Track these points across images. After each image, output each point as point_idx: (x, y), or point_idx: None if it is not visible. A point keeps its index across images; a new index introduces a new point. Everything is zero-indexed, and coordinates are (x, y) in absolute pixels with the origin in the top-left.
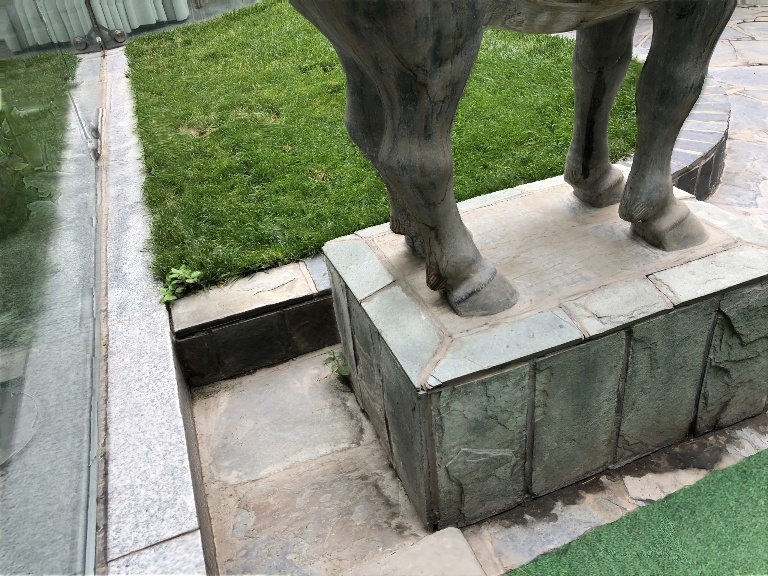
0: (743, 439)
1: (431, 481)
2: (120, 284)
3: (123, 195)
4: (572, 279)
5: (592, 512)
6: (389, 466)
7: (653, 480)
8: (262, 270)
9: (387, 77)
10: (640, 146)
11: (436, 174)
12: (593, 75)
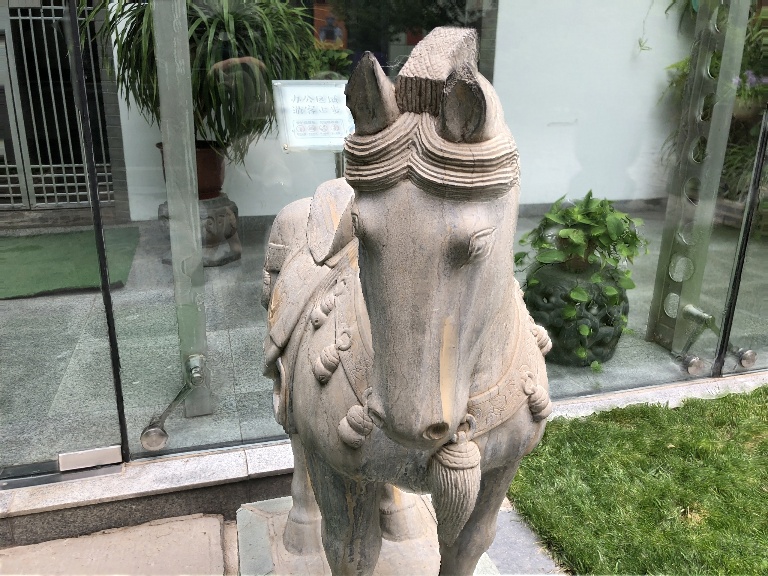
0: None
1: None
2: None
3: (639, 402)
4: None
5: None
6: None
7: None
8: None
9: None
10: None
11: None
12: None
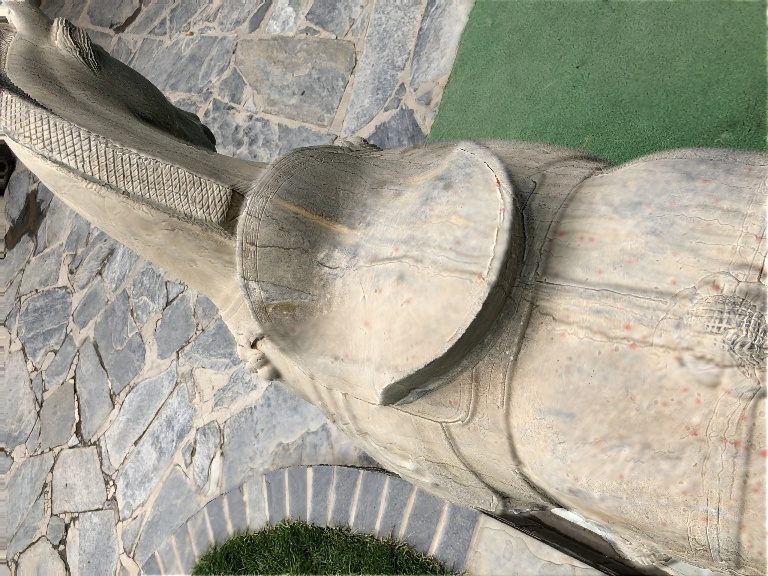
0: None
1: None
2: None
3: None
4: None
5: None
6: None
7: None
8: None
9: None
10: None
11: None
12: None
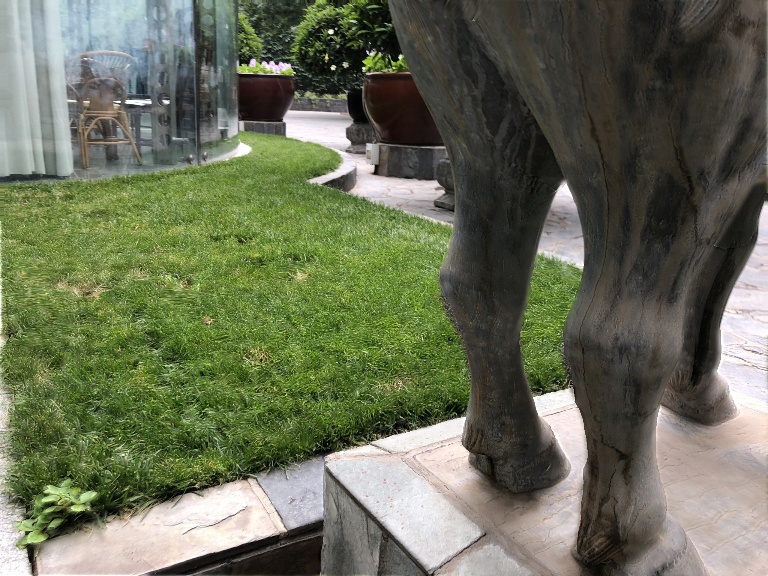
0: None
1: None
2: None
3: None
4: (765, 541)
5: None
6: None
7: None
8: (193, 490)
9: (640, 185)
10: None
11: (669, 363)
12: (722, 252)
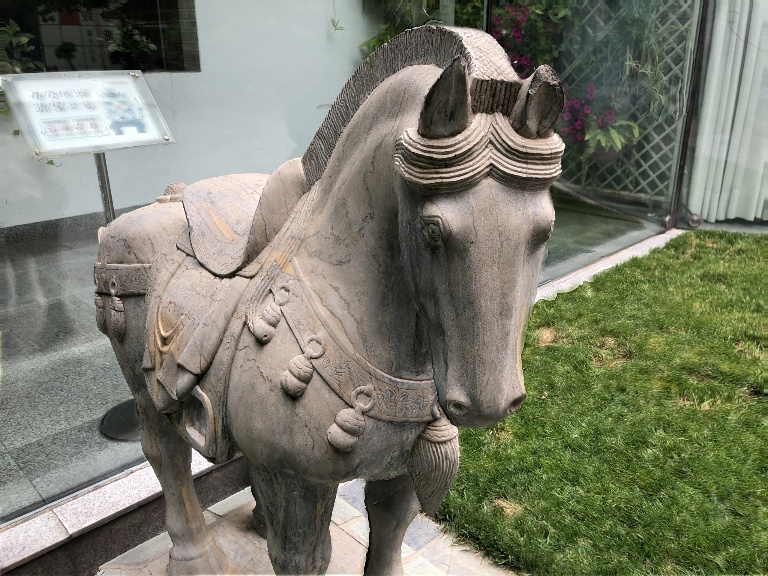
0: None
1: None
2: None
3: None
4: None
5: None
6: None
7: None
8: None
9: None
10: None
11: None
12: None
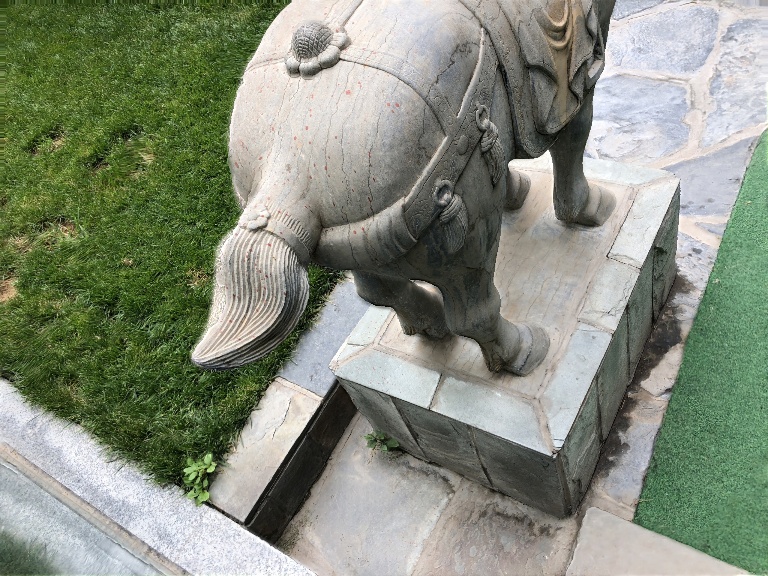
0: (681, 305)
1: (565, 495)
2: (131, 514)
3: (3, 418)
4: (565, 291)
5: (644, 425)
6: (491, 492)
7: (658, 374)
8: (252, 410)
9: (458, 281)
10: (562, 171)
11: (498, 311)
12: None
